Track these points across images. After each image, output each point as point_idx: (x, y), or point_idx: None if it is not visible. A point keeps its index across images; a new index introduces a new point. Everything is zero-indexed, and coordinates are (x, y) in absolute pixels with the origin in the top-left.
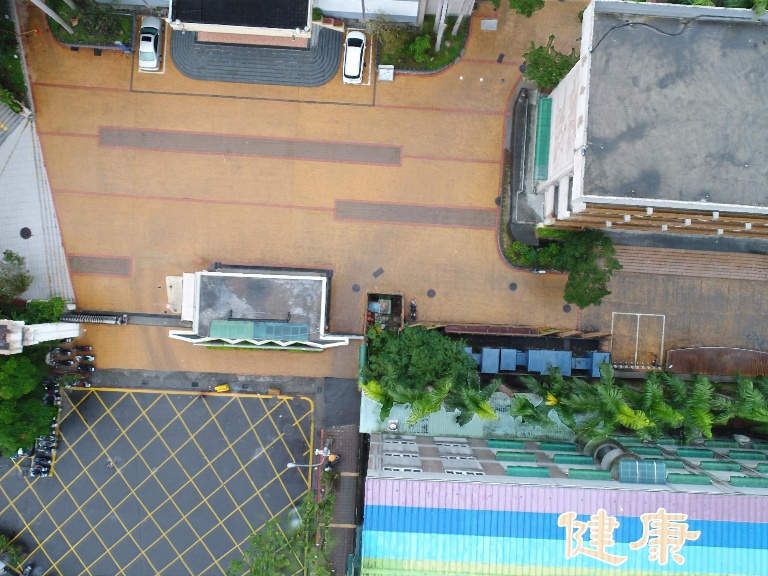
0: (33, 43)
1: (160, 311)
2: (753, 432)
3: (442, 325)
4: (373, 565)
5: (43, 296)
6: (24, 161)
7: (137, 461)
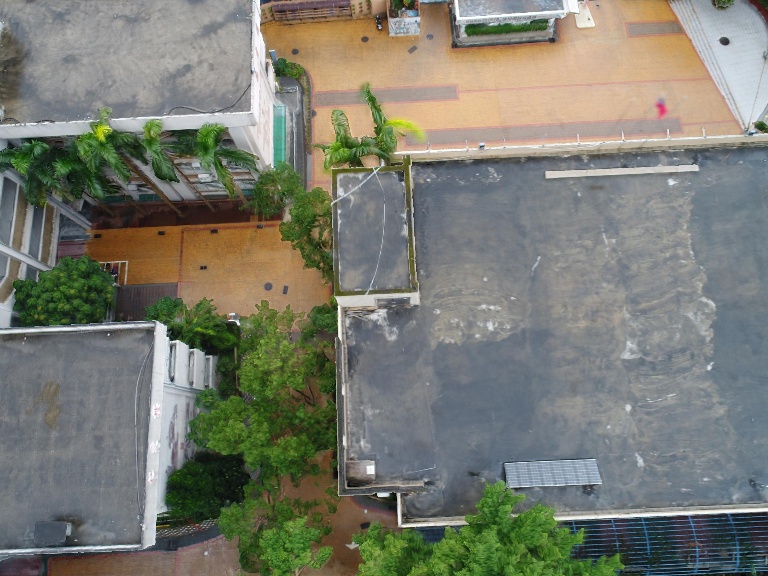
0: None
1: (594, 3)
2: None
3: (354, 3)
4: None
5: None
6: (743, 96)
7: None
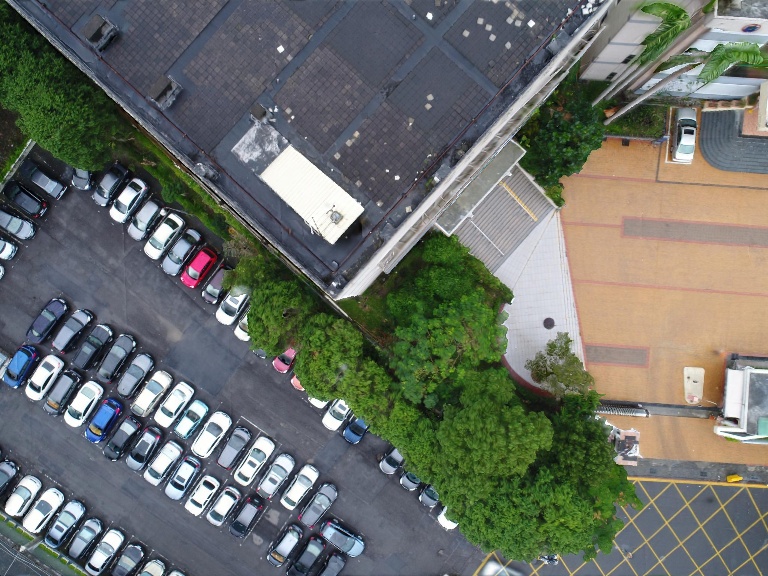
0: None
1: (674, 401)
2: None
3: None
4: None
5: None
6: (549, 251)
7: (644, 549)
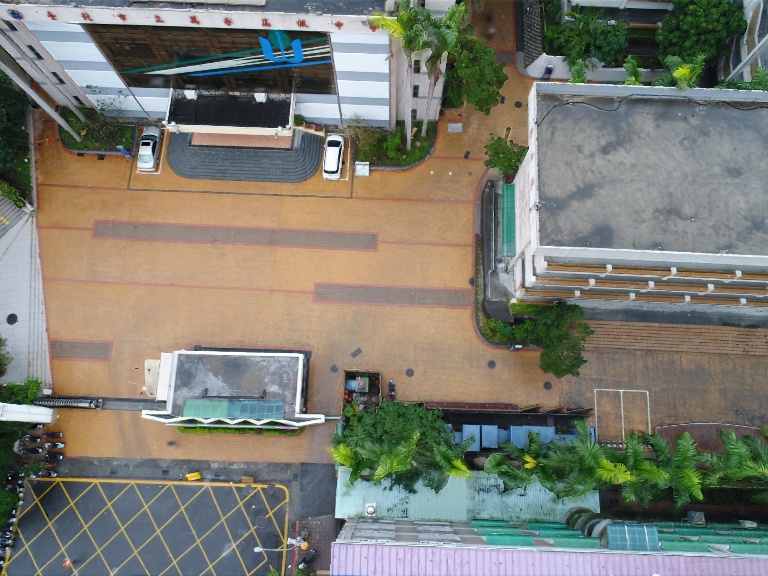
0: (44, 150)
1: (136, 395)
2: (760, 519)
3: (420, 402)
4: None
5: (20, 381)
6: (20, 252)
7: (96, 560)
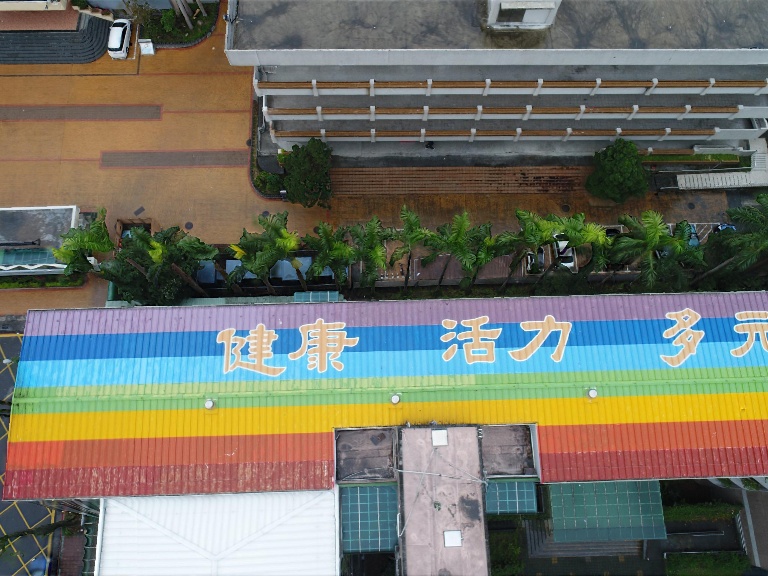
0: None
1: None
2: None
3: None
4: (25, 395)
5: None
6: None
7: None
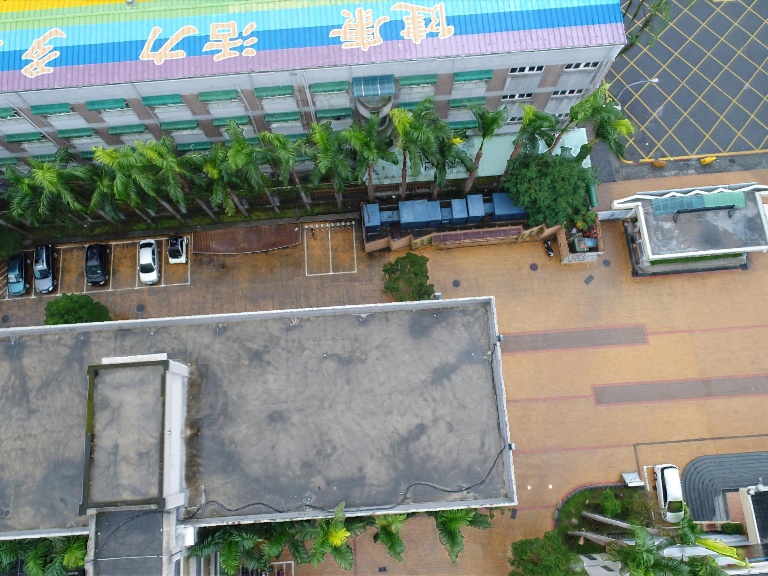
0: None
1: None
2: None
3: None
4: None
5: None
6: None
7: (764, 92)
